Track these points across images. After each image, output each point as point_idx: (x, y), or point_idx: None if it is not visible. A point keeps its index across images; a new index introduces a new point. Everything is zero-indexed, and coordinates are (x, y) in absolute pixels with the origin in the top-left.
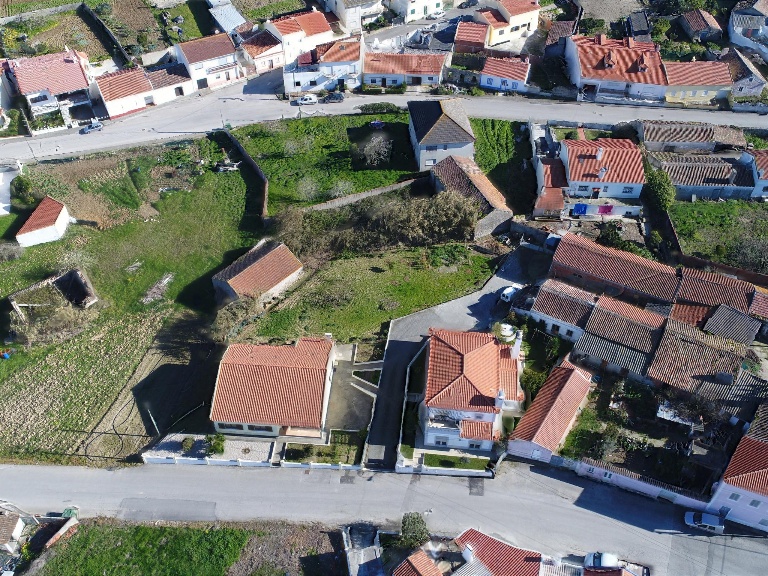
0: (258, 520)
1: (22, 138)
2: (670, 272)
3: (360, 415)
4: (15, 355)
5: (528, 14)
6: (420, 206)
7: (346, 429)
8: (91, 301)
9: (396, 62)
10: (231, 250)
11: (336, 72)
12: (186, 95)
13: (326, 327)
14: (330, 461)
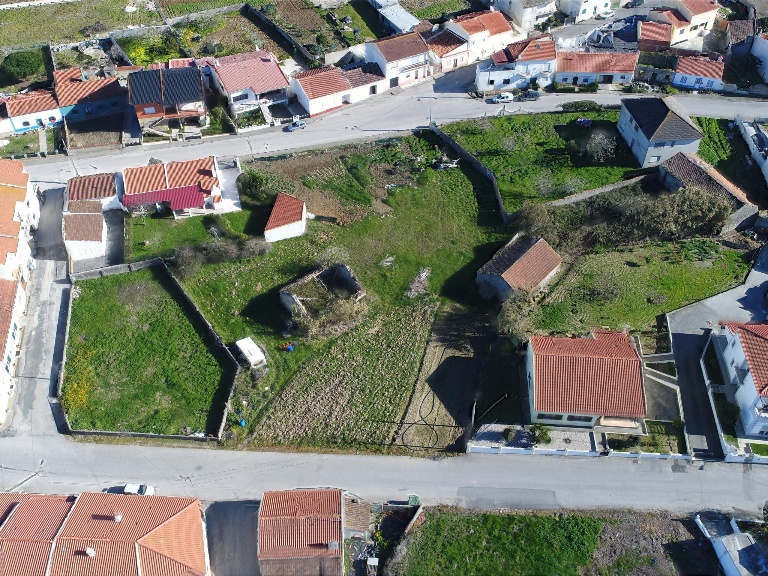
0: (603, 508)
1: (228, 136)
2: None
3: (667, 406)
4: (298, 348)
5: (708, 13)
6: (674, 201)
7: (660, 419)
8: (362, 295)
9: (589, 61)
10: (479, 245)
11: (531, 71)
12: (378, 94)
13: (601, 320)
14: (655, 451)
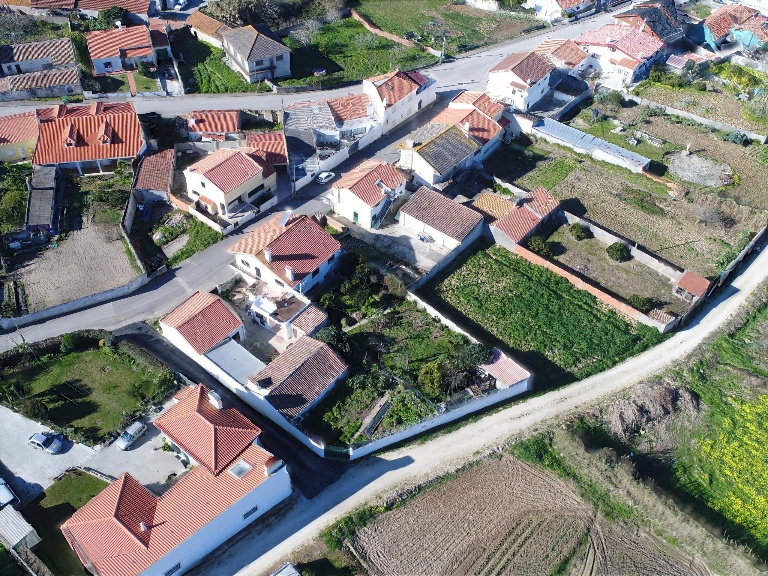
0: None
1: None
2: (83, 0)
3: None
4: None
5: None
6: None
7: None
8: None
9: None
10: (360, 5)
11: None
12: None
13: None
14: None
